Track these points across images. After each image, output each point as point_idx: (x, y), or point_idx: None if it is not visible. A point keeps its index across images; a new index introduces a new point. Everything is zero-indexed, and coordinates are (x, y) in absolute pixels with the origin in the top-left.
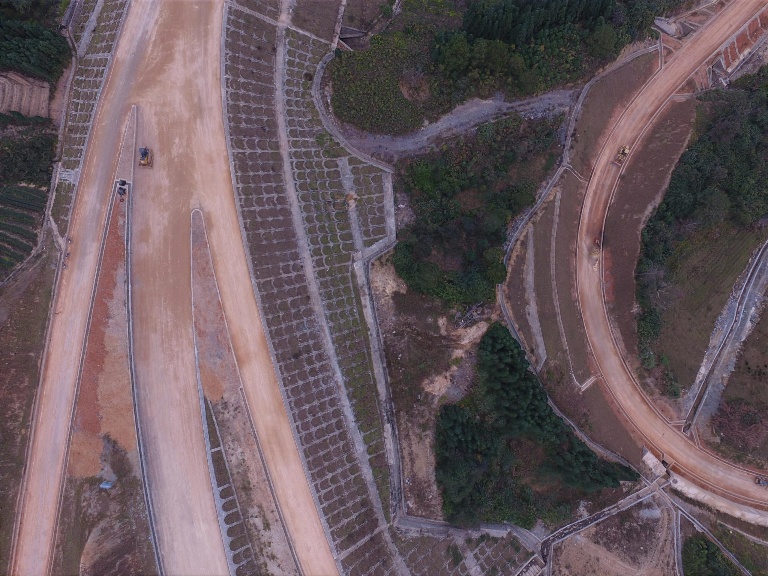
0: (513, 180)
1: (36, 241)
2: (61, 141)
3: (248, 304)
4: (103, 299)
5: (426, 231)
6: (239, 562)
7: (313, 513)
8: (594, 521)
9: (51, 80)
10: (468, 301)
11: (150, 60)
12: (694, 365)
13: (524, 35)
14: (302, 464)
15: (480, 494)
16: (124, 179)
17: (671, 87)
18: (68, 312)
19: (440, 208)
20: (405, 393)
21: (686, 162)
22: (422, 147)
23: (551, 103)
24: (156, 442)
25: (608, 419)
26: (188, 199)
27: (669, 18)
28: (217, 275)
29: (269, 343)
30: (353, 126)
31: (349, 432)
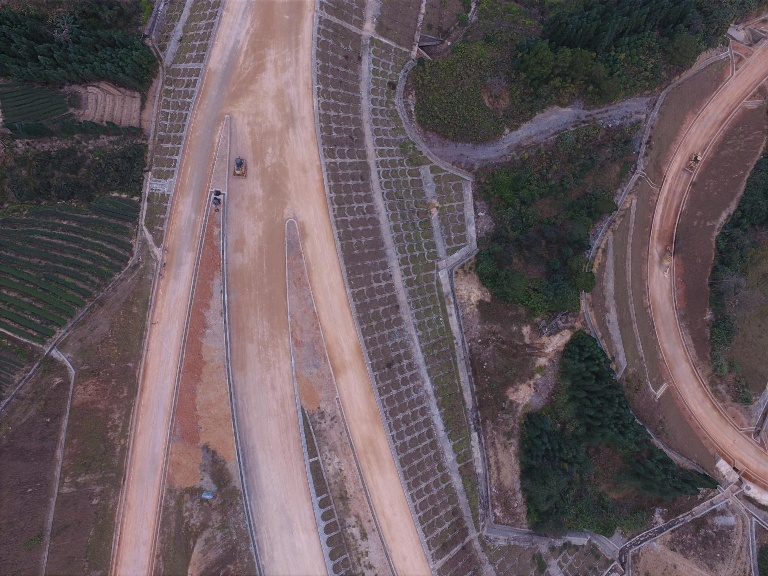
0: (589, 187)
1: (132, 251)
2: (151, 151)
3: (343, 314)
4: (200, 309)
5: (508, 239)
6: (338, 572)
7: (409, 522)
8: (669, 528)
9: (142, 90)
10: (553, 309)
11: (242, 70)
12: (765, 372)
13: (606, 43)
14: (398, 474)
15: (564, 502)
16: (219, 189)
17: (742, 94)
18: (165, 322)
19: (518, 216)
20: (491, 401)
21: (762, 169)
22: (503, 155)
23: (628, 111)
24: (254, 452)
25: (681, 426)
26: (282, 209)
27: (738, 25)
28: (312, 285)
29: (364, 353)
30: (436, 135)
31: (439, 441)
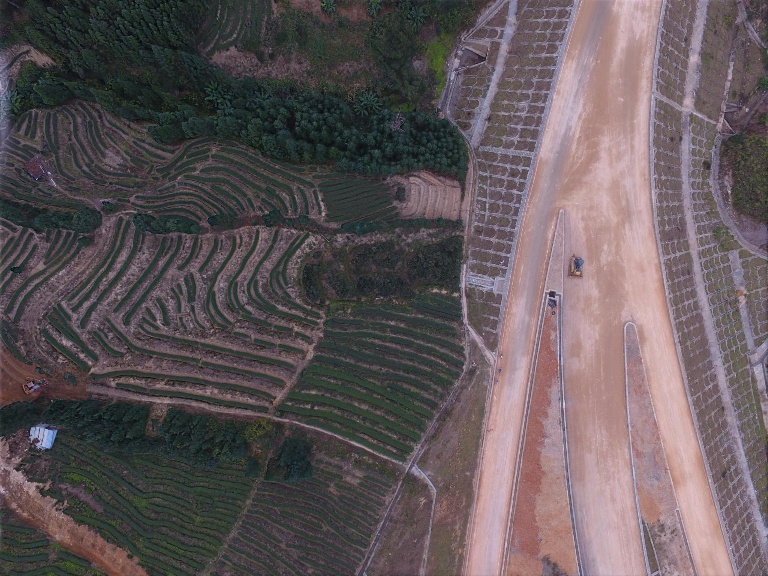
0: None
1: (464, 355)
2: (465, 242)
3: (683, 423)
4: (538, 417)
5: None
6: None
7: None
8: None
9: (463, 179)
10: None
11: (575, 159)
12: None
13: None
14: None
15: None
16: (554, 290)
17: None
18: (500, 429)
19: None
20: None
21: None
22: None
23: None
24: (595, 565)
25: None
26: (619, 311)
27: None
28: (651, 392)
29: (706, 464)
30: (750, 218)
31: (761, 547)
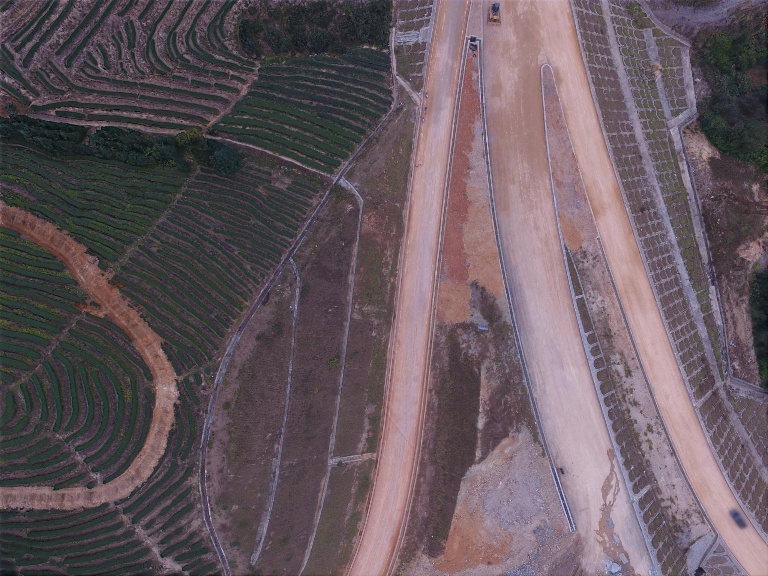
0: None
1: (392, 97)
2: (394, 7)
3: (600, 157)
4: (463, 151)
5: (731, 101)
6: (609, 406)
7: (671, 361)
8: None
9: None
10: None
11: None
12: None
13: None
14: (660, 312)
15: None
16: (474, 36)
17: None
18: (427, 165)
19: (733, 83)
20: (726, 257)
21: None
22: (723, 18)
23: None
24: (522, 289)
25: None
26: (536, 55)
27: None
28: (568, 128)
29: (623, 194)
30: None
31: (684, 290)
